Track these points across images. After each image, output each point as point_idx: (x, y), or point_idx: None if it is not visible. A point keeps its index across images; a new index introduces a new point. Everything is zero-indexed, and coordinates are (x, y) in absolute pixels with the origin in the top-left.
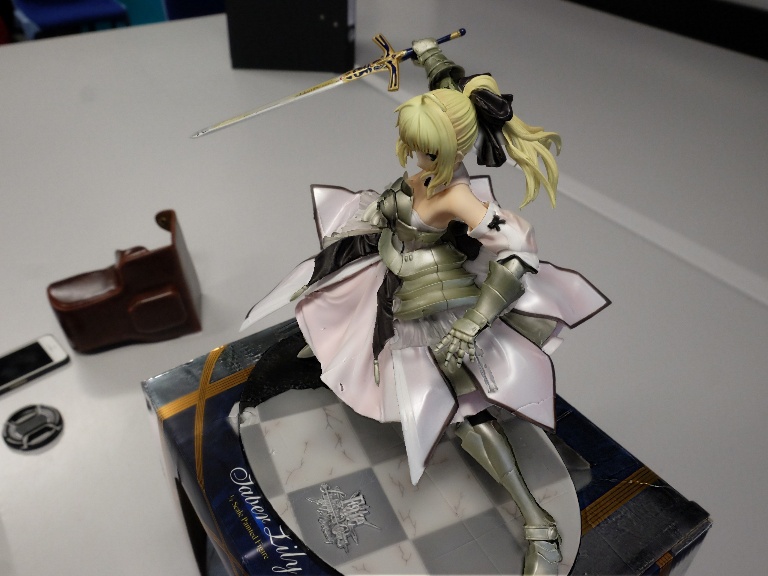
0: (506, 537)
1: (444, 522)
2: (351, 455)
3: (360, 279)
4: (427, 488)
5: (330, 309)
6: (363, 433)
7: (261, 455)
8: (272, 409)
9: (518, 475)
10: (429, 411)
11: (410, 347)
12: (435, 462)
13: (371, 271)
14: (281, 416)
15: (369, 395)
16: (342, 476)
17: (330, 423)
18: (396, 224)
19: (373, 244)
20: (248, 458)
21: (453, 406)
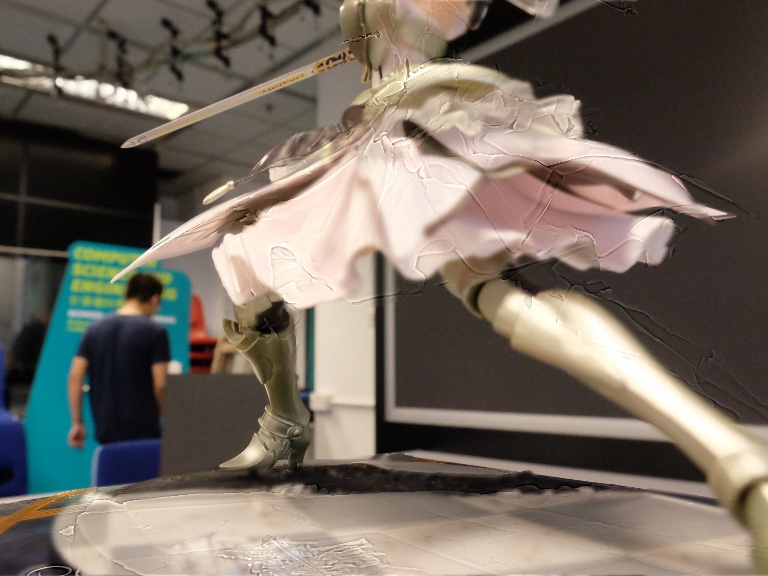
0: (767, 564)
1: (590, 560)
2: (328, 525)
3: (339, 171)
4: (518, 539)
5: (289, 222)
6: (351, 511)
7: (117, 529)
8: (157, 502)
9: (730, 362)
10: (506, 170)
11: (442, 157)
12: (518, 522)
13: (356, 159)
14: (175, 506)
15: (369, 286)
16: (310, 539)
17: (279, 509)
18: (397, 5)
19: (358, 114)
20: (83, 531)
21: (551, 173)
